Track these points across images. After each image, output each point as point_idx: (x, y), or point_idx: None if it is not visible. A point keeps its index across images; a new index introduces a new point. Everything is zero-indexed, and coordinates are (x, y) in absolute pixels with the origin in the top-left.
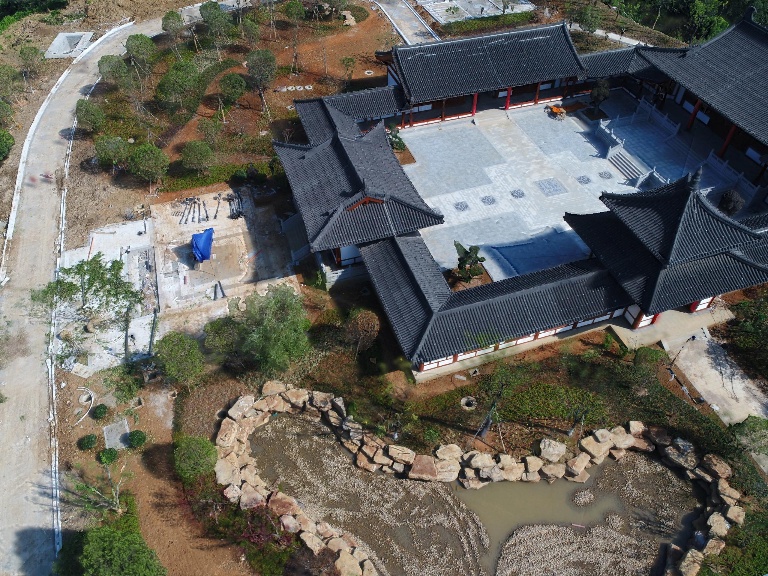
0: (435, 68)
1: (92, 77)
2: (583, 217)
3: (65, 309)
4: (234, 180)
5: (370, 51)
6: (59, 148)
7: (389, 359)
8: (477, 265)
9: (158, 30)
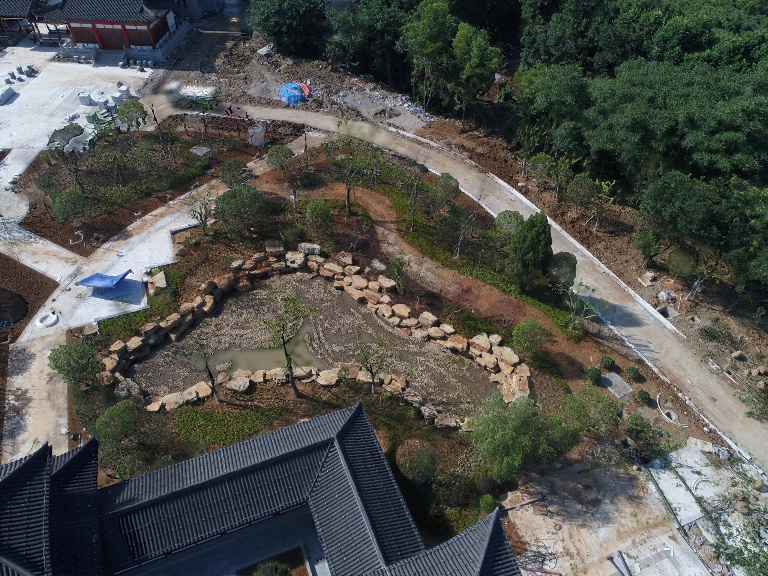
0: None
1: None
2: None
3: None
4: None
5: None
6: None
7: None
8: None
9: None
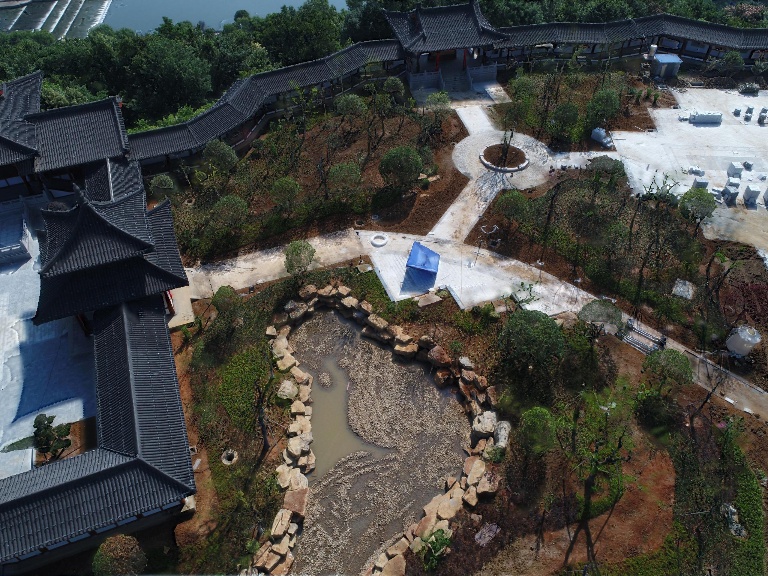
0: None
1: None
2: (47, 306)
3: None
4: None
5: None
6: None
7: (156, 542)
8: (53, 429)
9: None
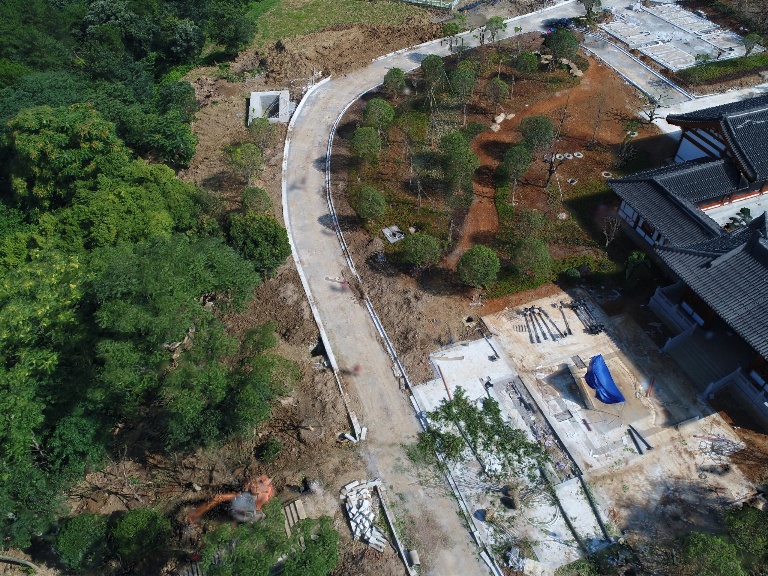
0: (767, 137)
1: (319, 147)
2: None
3: (462, 473)
4: (562, 280)
5: (619, 107)
6: (329, 242)
7: None
8: None
9: (362, 86)
